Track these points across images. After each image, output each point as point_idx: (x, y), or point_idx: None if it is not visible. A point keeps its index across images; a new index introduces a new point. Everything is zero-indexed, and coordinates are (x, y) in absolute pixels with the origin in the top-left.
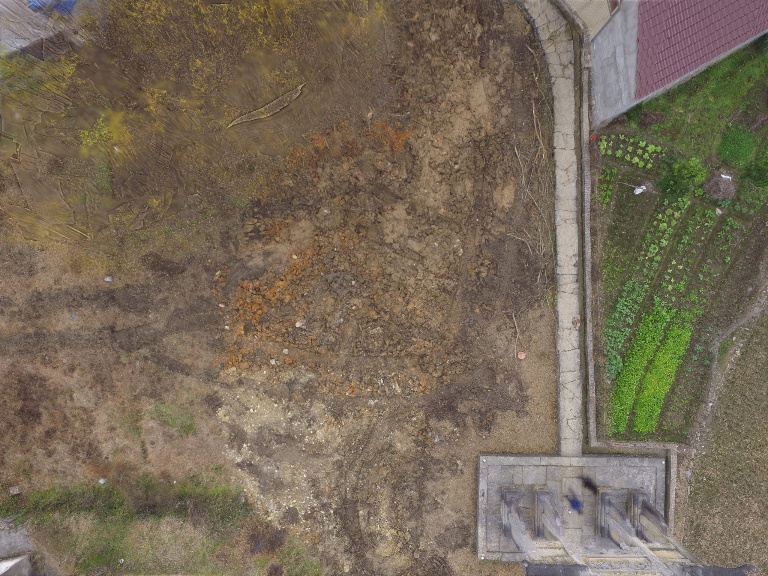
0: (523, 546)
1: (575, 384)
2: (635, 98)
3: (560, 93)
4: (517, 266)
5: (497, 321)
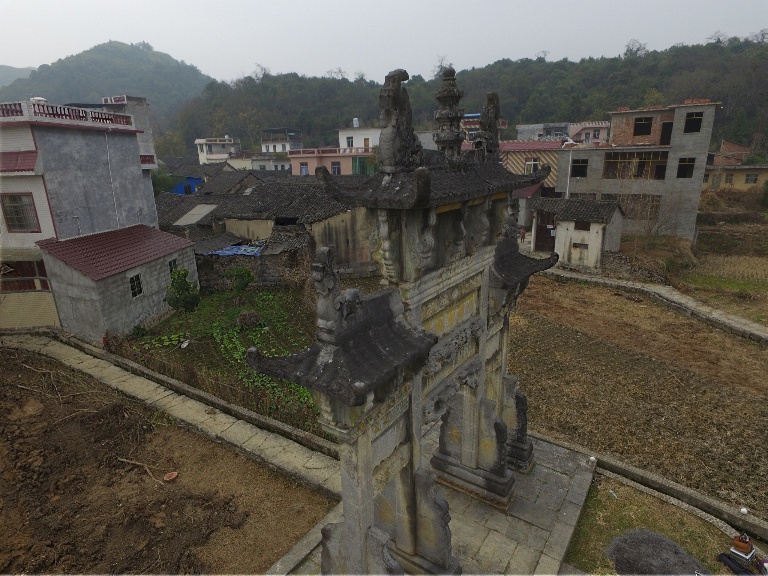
0: (352, 510)
1: (271, 440)
2: (95, 281)
3: (51, 351)
4: (91, 434)
5: (99, 481)
